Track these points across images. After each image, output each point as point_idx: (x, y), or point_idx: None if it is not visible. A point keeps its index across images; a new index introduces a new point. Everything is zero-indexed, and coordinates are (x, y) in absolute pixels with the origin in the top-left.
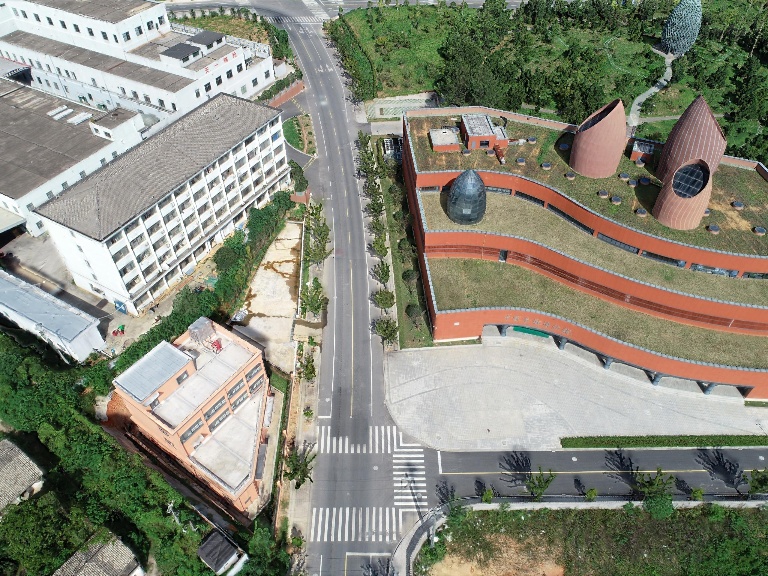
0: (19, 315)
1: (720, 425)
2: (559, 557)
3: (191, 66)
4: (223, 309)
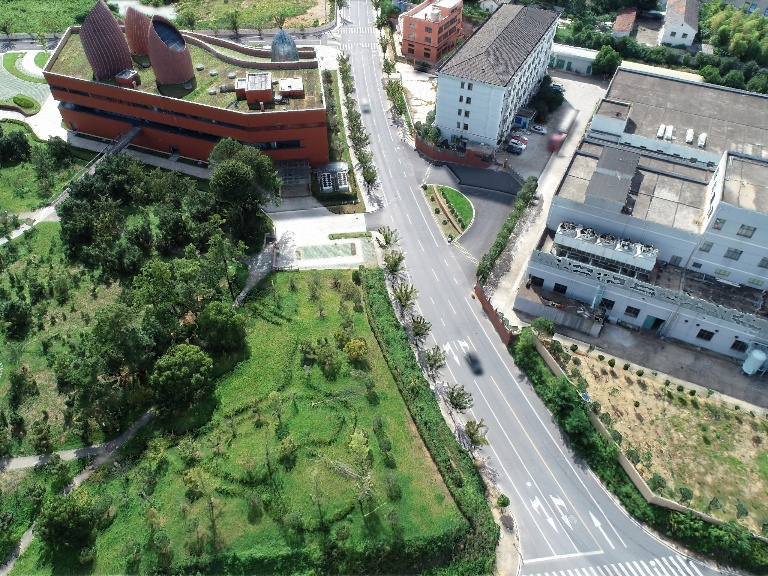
0: None
1: None
2: None
3: (595, 164)
4: None
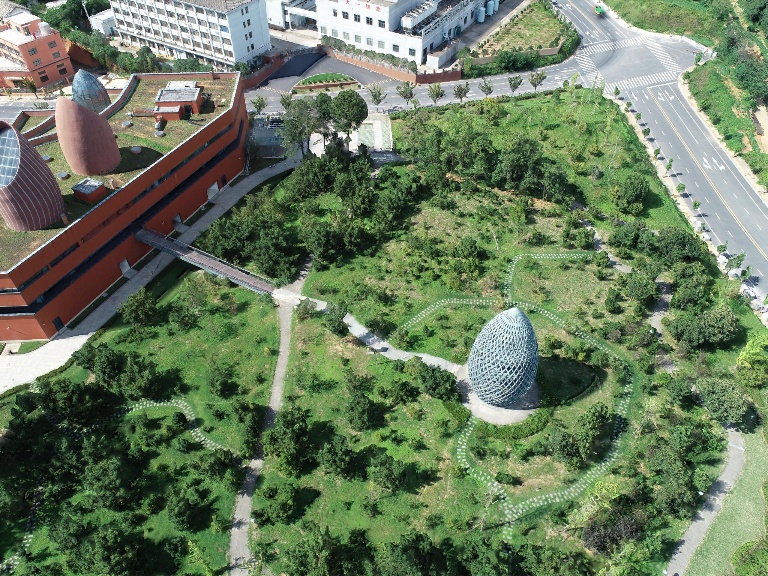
0: None
1: None
2: None
3: None
4: (106, 62)
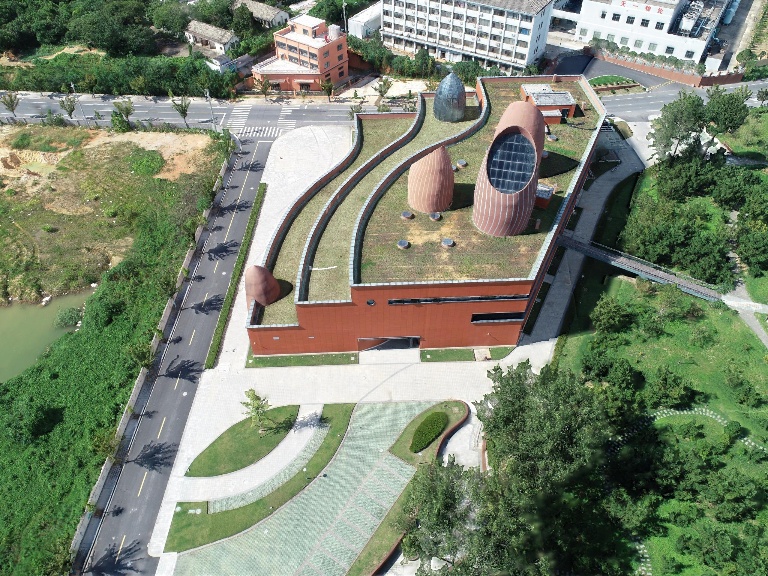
0: (369, 7)
1: (256, 259)
2: (196, 173)
3: None
4: (382, 64)
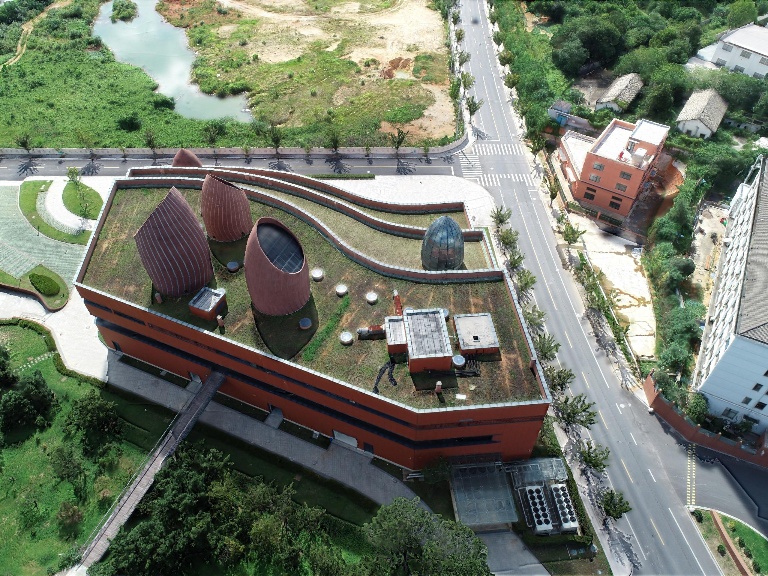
0: None
1: None
2: (390, 140)
3: None
4: None
